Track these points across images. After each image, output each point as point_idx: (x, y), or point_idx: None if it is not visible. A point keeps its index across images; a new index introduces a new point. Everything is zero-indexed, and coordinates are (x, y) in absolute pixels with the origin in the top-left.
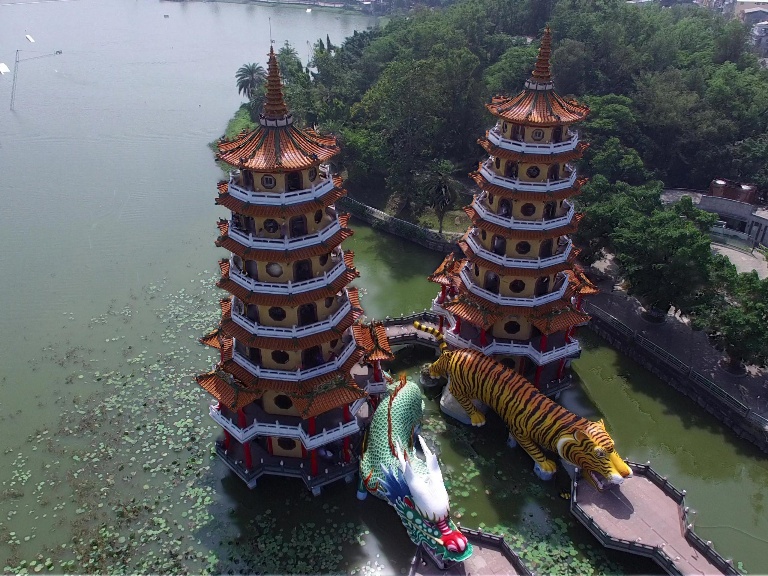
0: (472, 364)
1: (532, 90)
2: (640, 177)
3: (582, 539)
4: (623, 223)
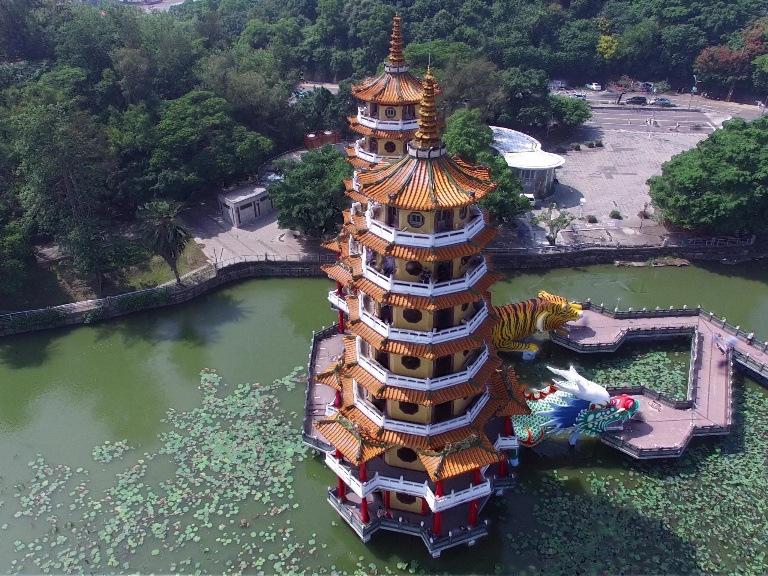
0: None
1: (401, 73)
2: (263, 155)
3: (594, 363)
4: None
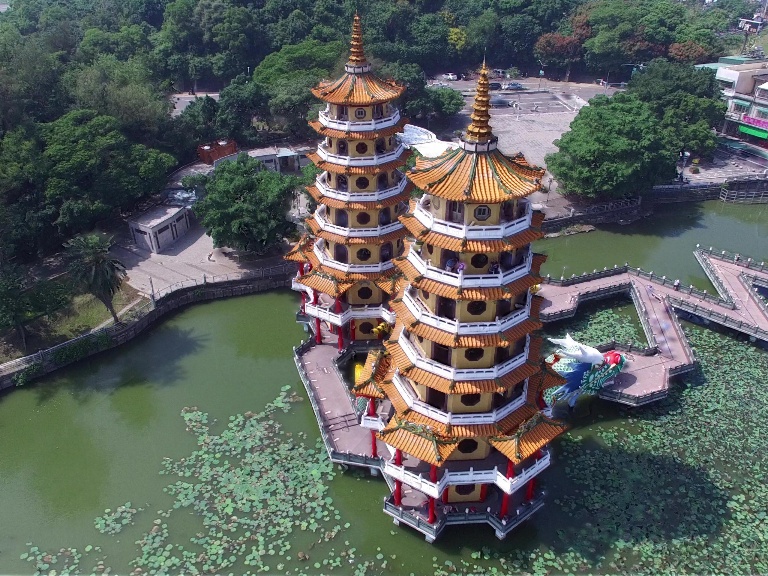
0: None
1: (365, 73)
2: None
3: None
4: (299, 185)
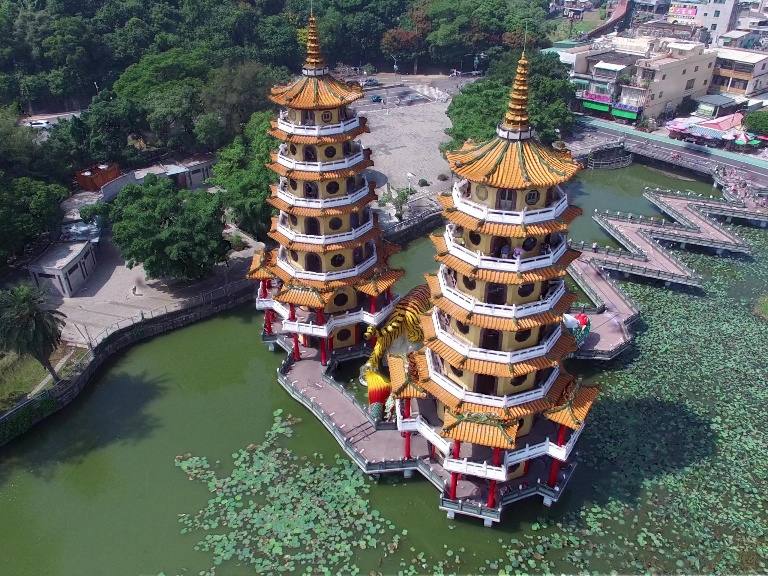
0: None
1: None
2: None
3: None
4: (227, 200)
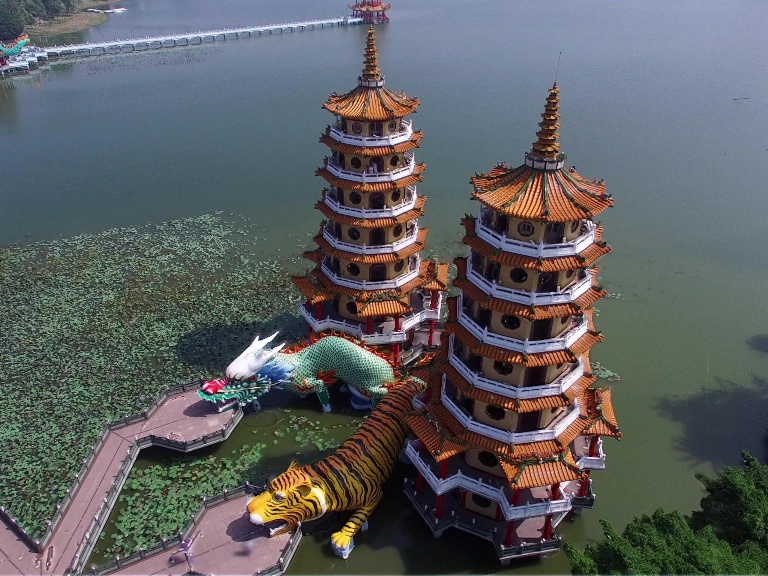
0: (391, 389)
1: None
2: None
3: None
4: (742, 545)
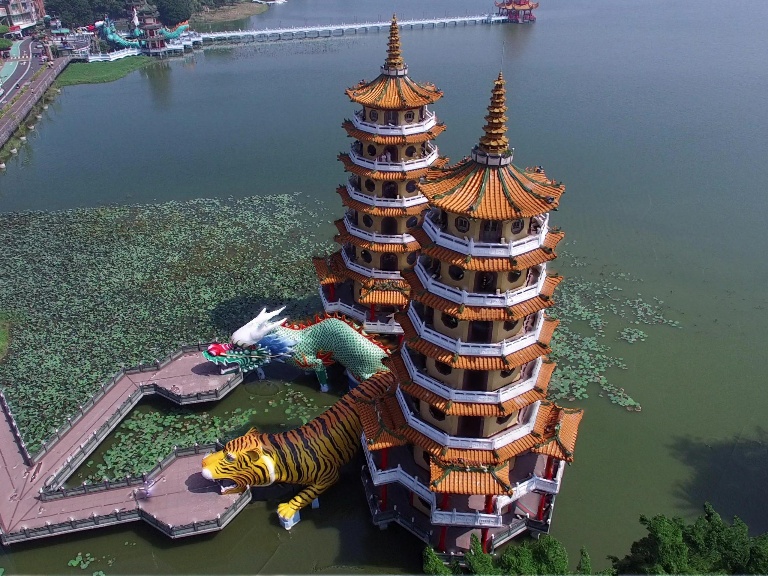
0: (370, 377)
1: None
2: None
3: None
4: None
